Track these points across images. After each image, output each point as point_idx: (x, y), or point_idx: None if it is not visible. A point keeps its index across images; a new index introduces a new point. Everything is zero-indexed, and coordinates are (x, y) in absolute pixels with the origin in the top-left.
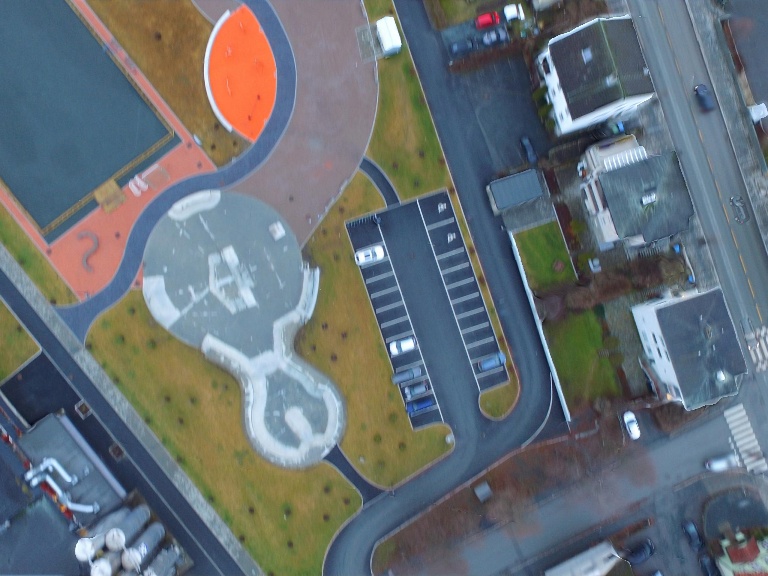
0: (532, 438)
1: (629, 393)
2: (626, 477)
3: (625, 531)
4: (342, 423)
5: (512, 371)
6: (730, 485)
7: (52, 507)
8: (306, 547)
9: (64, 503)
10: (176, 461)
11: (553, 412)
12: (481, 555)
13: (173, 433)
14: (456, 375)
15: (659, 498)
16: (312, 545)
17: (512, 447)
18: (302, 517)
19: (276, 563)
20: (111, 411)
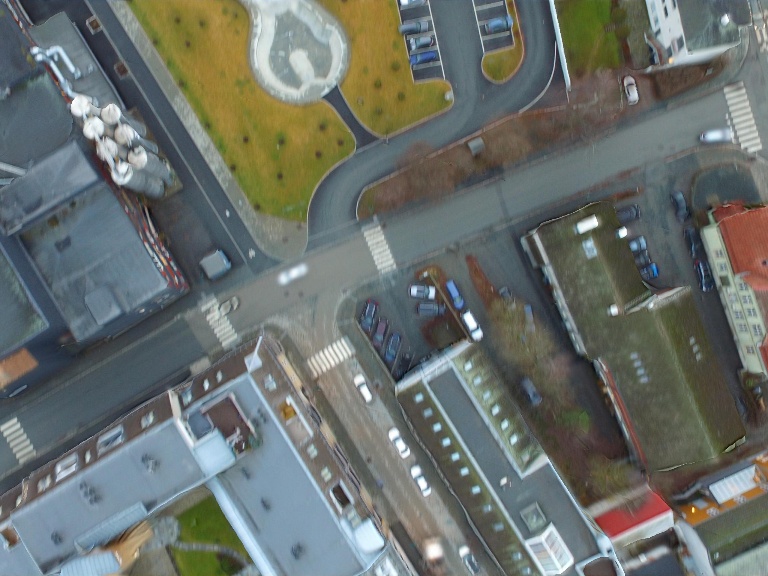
0: (530, 105)
1: (631, 67)
2: (620, 144)
3: (613, 196)
4: (345, 65)
5: (518, 36)
6: (722, 160)
7: (53, 85)
8: (295, 181)
9: (65, 89)
10: (178, 85)
11: (554, 81)
12: (467, 209)
13: (178, 56)
14: (462, 34)
15: (650, 168)
16: (301, 180)
17: (510, 111)
18: (295, 148)
19: (264, 195)
20: (121, 29)
